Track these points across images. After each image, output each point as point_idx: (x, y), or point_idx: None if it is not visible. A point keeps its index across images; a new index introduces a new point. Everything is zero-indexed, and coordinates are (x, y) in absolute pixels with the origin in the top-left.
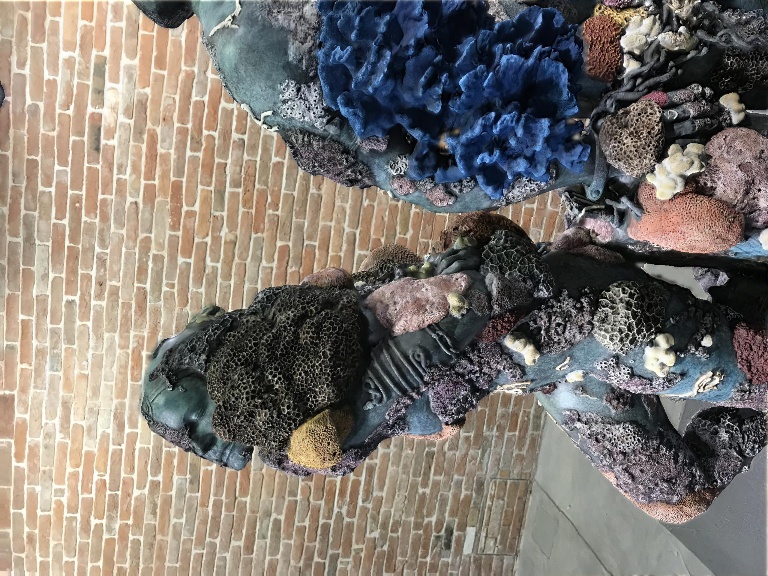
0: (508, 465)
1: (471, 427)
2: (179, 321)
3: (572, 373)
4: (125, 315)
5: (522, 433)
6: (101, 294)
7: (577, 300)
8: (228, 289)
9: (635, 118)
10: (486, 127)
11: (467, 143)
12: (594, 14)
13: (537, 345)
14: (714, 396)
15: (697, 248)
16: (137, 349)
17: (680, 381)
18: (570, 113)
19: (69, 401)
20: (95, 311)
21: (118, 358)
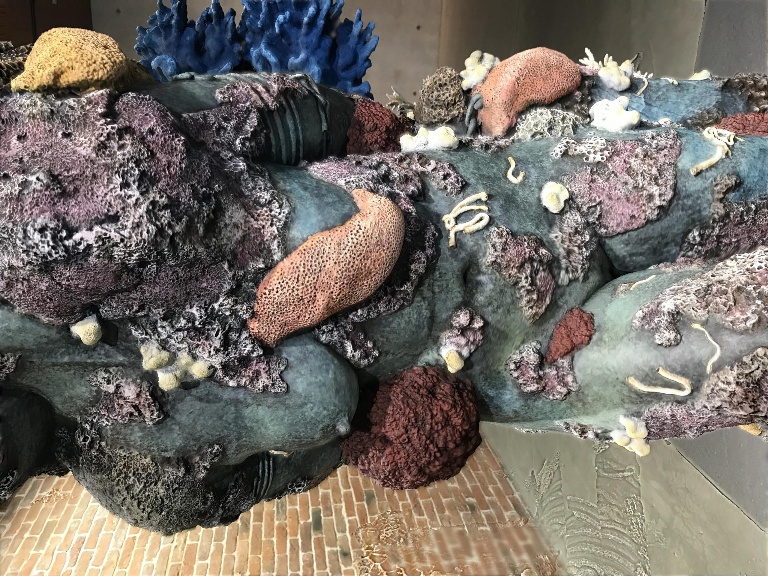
0: None
1: None
2: None
3: (543, 191)
4: None
5: None
6: None
7: None
8: None
9: None
10: (272, 8)
11: (268, 42)
12: None
13: None
14: (759, 151)
15: (538, 62)
16: None
17: (682, 139)
18: (338, 6)
19: None
20: None
21: None
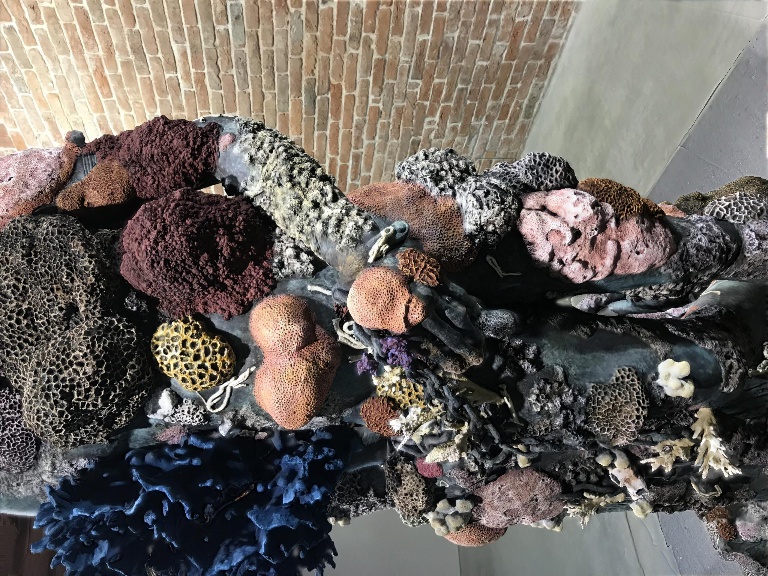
0: (495, 148)
1: (459, 118)
2: (132, 42)
3: None
4: (72, 37)
5: (512, 121)
6: (37, 18)
7: (382, 497)
8: (176, 3)
9: (401, 497)
10: None
11: None
12: (376, 391)
13: (348, 515)
14: None
15: None
16: (98, 72)
17: None
18: None
19: (51, 117)
20: (39, 35)
21: (82, 81)
